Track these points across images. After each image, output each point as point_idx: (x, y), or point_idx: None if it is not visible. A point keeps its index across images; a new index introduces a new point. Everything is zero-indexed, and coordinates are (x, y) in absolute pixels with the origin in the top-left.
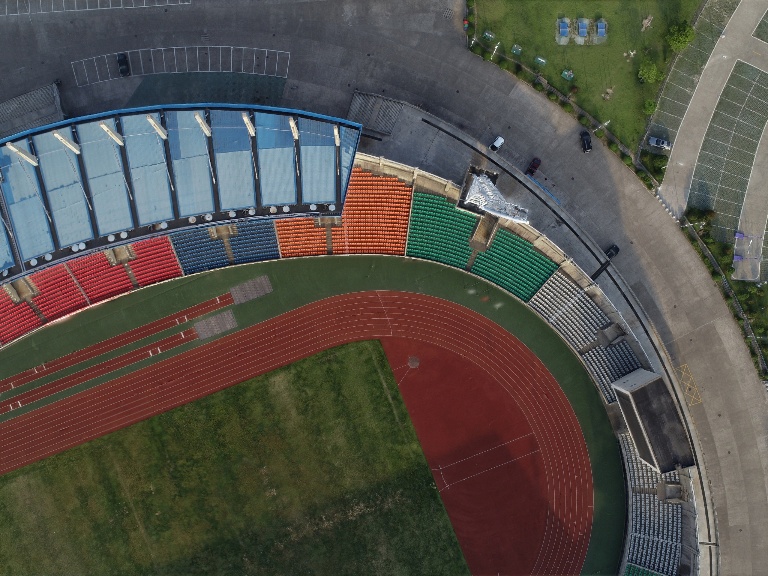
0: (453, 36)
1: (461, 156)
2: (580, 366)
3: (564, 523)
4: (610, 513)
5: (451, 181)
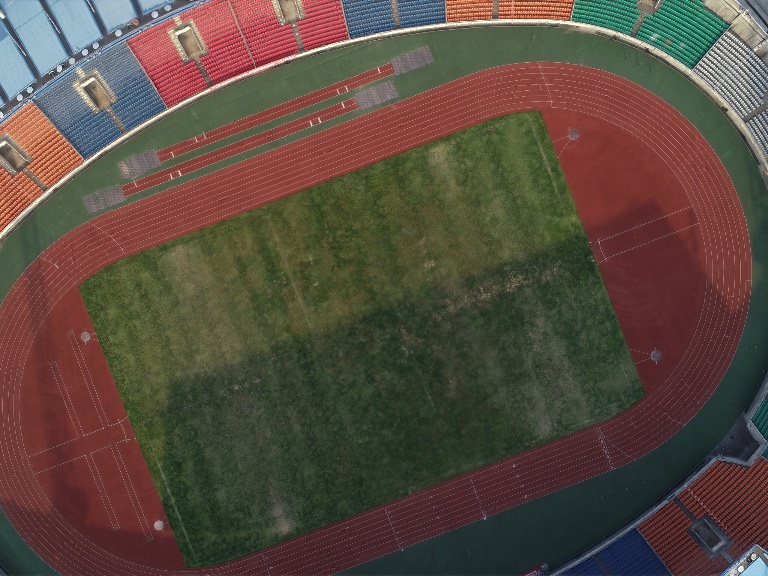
0: None
1: None
2: (740, 139)
3: (722, 297)
4: (767, 287)
5: None
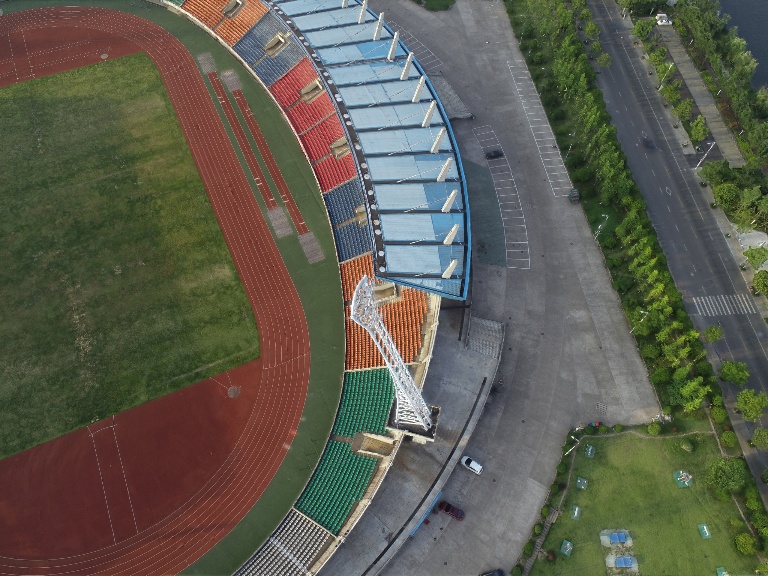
0: (580, 413)
1: (453, 419)
2: None
3: None
4: None
5: (422, 391)
